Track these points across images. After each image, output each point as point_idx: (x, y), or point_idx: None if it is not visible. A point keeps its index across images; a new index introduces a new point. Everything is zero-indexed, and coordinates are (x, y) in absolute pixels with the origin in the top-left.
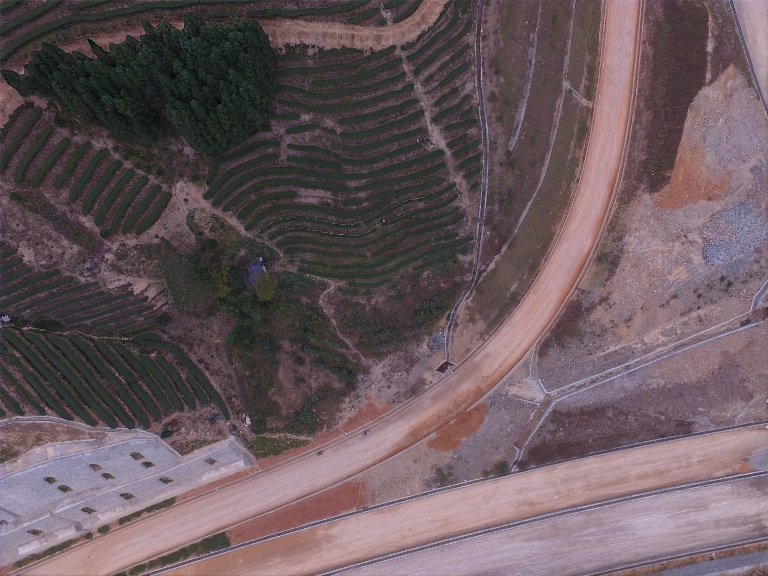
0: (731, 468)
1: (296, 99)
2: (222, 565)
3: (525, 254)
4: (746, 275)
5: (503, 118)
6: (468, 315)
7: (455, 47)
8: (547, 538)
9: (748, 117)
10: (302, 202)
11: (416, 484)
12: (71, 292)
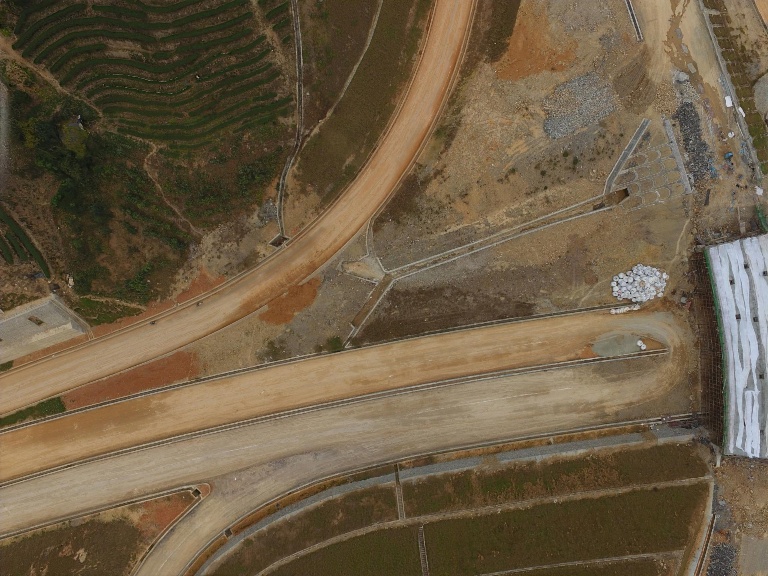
0: (573, 353)
1: None
2: (58, 430)
3: (358, 124)
4: (592, 151)
5: None
6: (298, 186)
7: None
8: (381, 416)
9: None
10: (114, 56)
11: (248, 357)
12: None
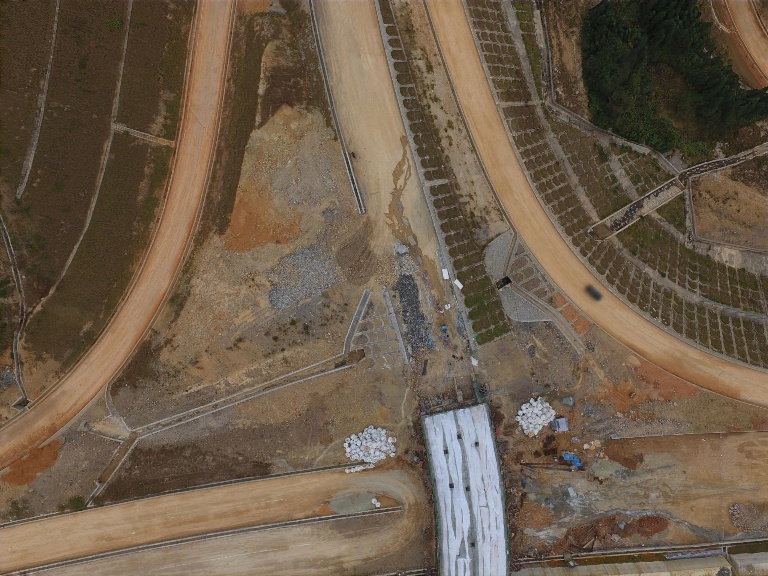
0: (311, 510)
1: None
2: None
3: (90, 295)
4: (321, 319)
5: (2, 167)
6: (33, 354)
7: None
8: (124, 572)
9: (321, 158)
10: None
11: None
12: None
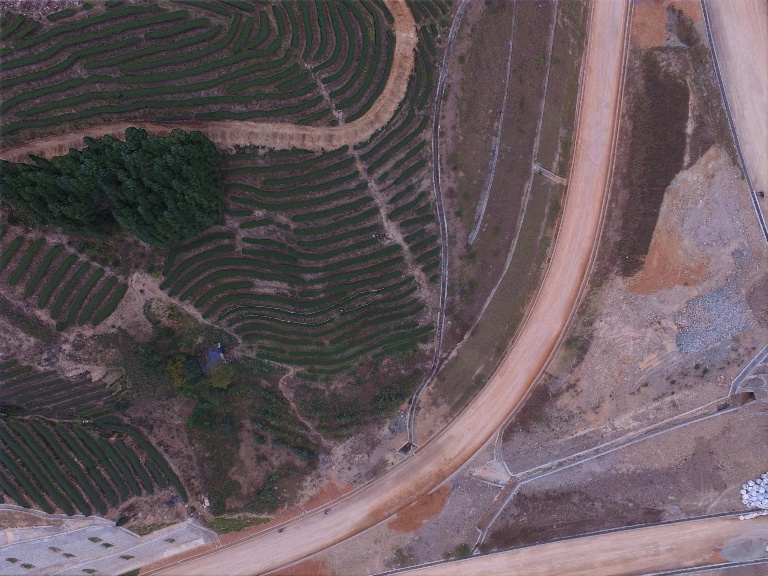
0: (701, 558)
1: (249, 196)
2: None
3: (490, 338)
4: (723, 362)
5: (462, 212)
6: (430, 399)
7: (411, 144)
8: None
9: (731, 198)
10: (259, 292)
11: (376, 564)
12: (30, 380)
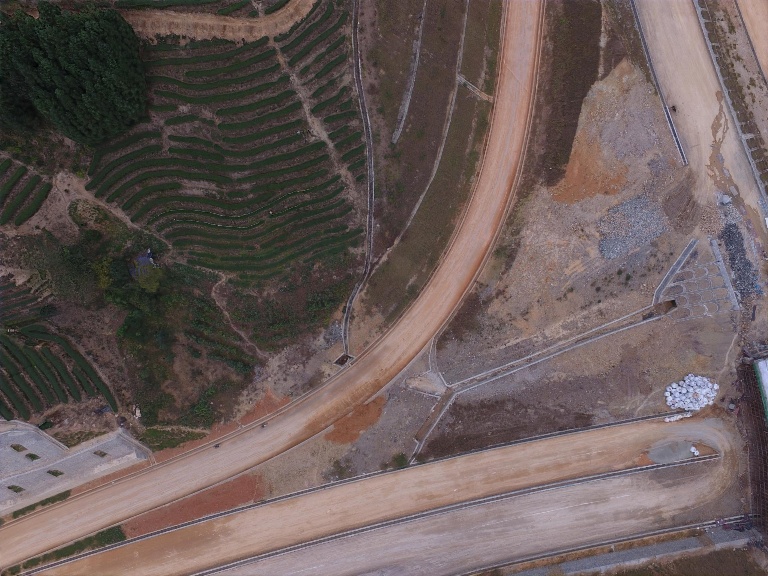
0: (631, 461)
1: (172, 90)
2: (118, 558)
3: (422, 247)
4: (644, 269)
5: (385, 110)
6: (364, 308)
7: (331, 39)
8: (446, 531)
9: (645, 112)
10: (187, 194)
11: (314, 477)
12: None
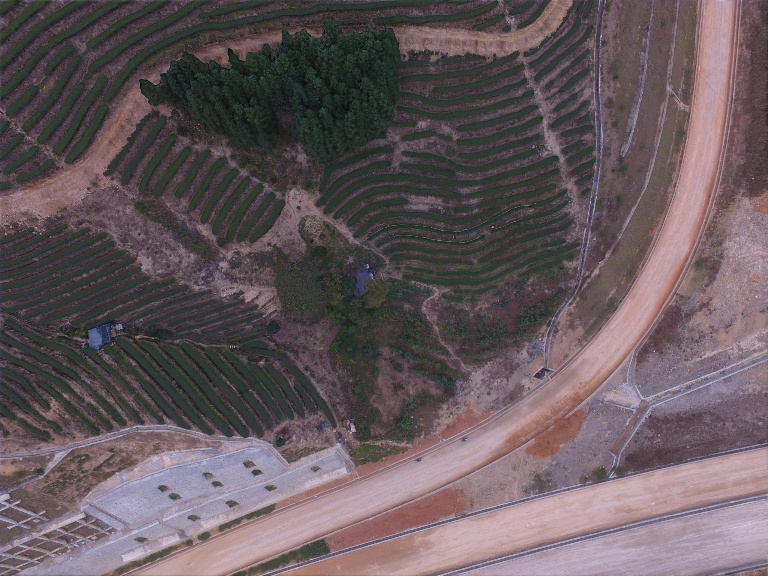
0: None
1: (415, 106)
2: (321, 572)
3: (625, 260)
4: None
5: (618, 124)
6: (568, 321)
7: (576, 53)
8: (644, 544)
9: None
10: (412, 209)
11: (514, 491)
12: (185, 300)
